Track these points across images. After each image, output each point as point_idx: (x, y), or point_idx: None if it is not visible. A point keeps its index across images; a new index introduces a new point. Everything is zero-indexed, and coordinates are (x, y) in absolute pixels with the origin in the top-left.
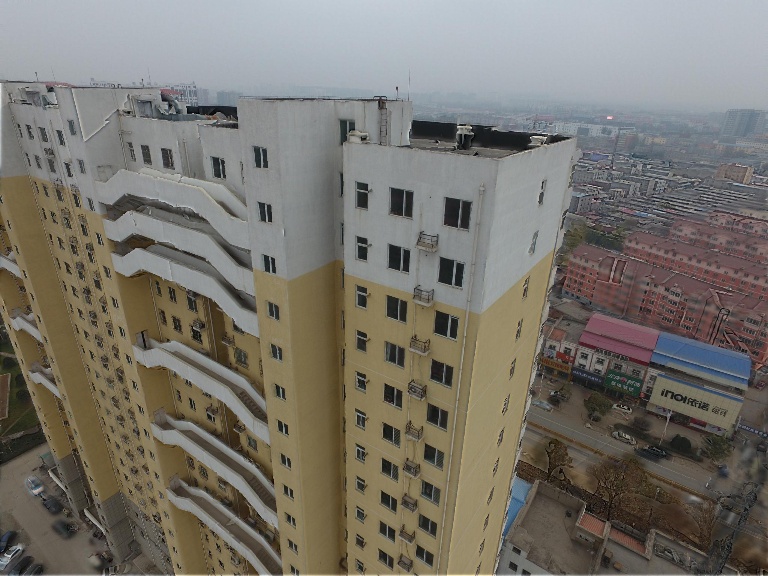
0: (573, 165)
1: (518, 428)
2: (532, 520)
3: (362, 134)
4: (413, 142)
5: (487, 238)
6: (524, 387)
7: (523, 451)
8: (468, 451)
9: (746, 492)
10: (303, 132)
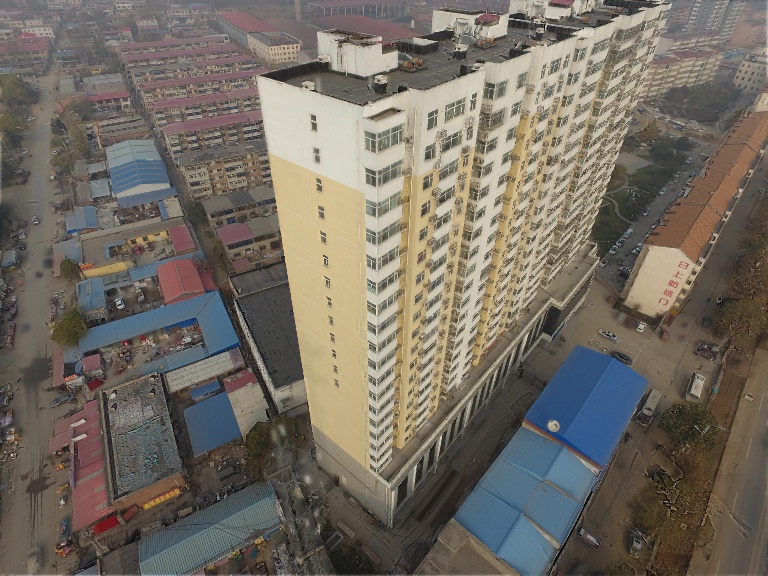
0: (367, 131)
1: None
2: (486, 570)
3: (319, 57)
4: (413, 84)
5: None
6: (354, 284)
7: None
8: (286, 234)
9: None
10: None
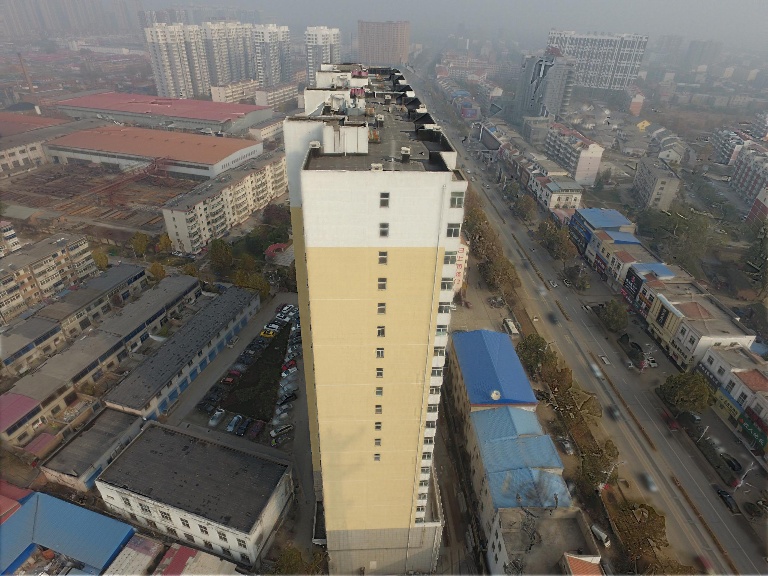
0: (454, 191)
1: (423, 370)
2: (542, 525)
3: (312, 143)
4: None
5: (303, 208)
6: (419, 339)
7: (645, 511)
8: (321, 327)
9: (525, 523)
10: (301, 137)
